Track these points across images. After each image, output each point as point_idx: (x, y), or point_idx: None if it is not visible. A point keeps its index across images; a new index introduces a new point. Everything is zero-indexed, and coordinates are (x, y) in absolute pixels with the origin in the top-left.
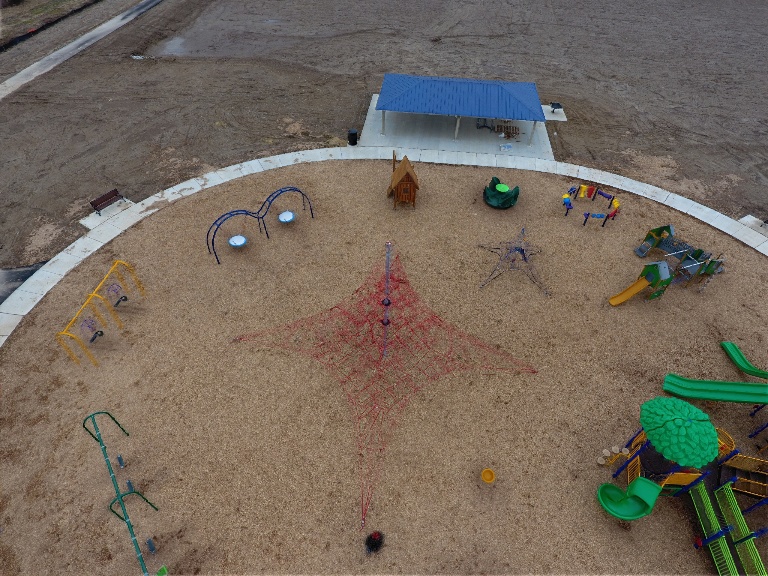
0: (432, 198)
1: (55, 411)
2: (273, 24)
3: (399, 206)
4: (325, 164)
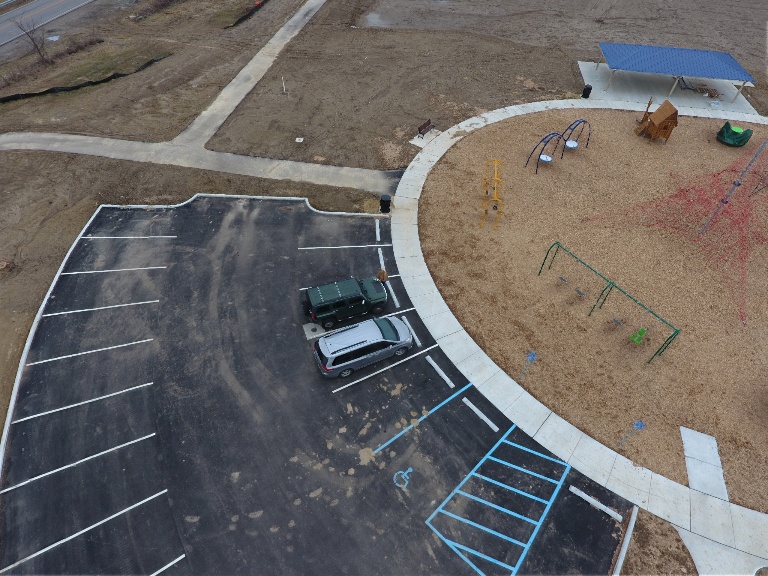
0: (674, 137)
1: (487, 254)
2: (447, 4)
3: (652, 142)
4: (572, 111)
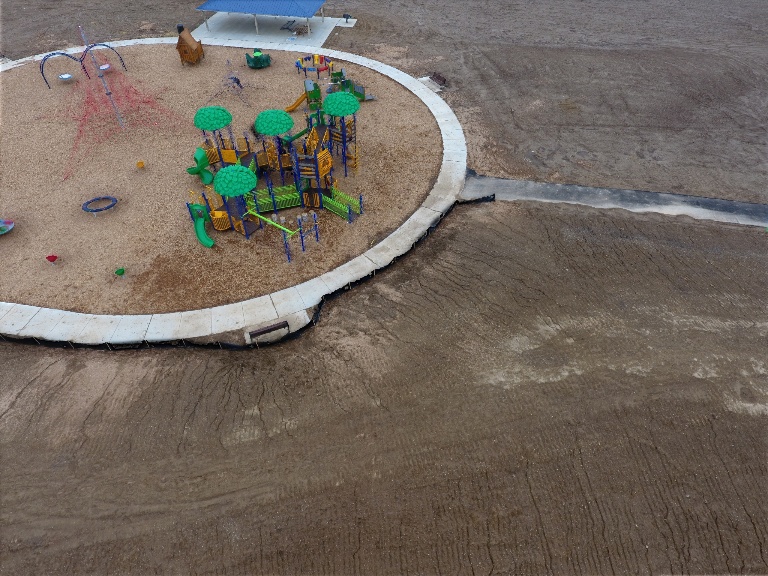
0: (214, 63)
1: None
2: None
3: (188, 66)
4: (154, 45)
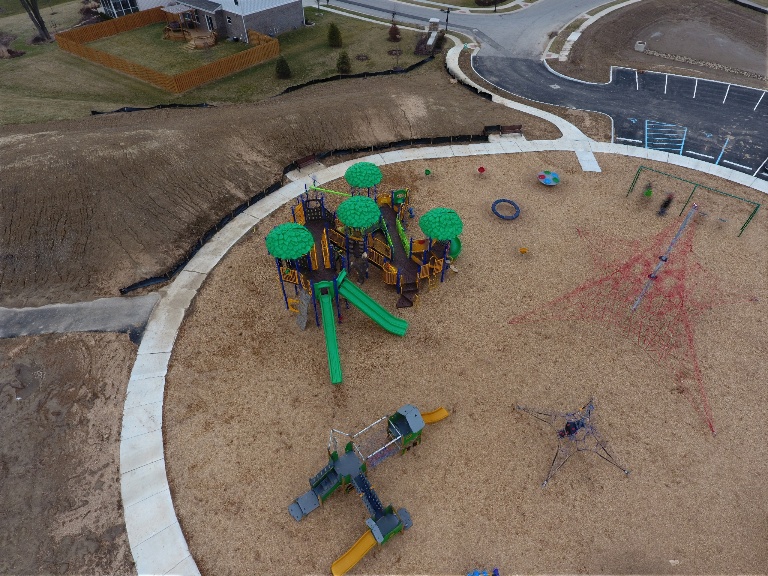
0: None
1: None
2: None
3: None
4: None
